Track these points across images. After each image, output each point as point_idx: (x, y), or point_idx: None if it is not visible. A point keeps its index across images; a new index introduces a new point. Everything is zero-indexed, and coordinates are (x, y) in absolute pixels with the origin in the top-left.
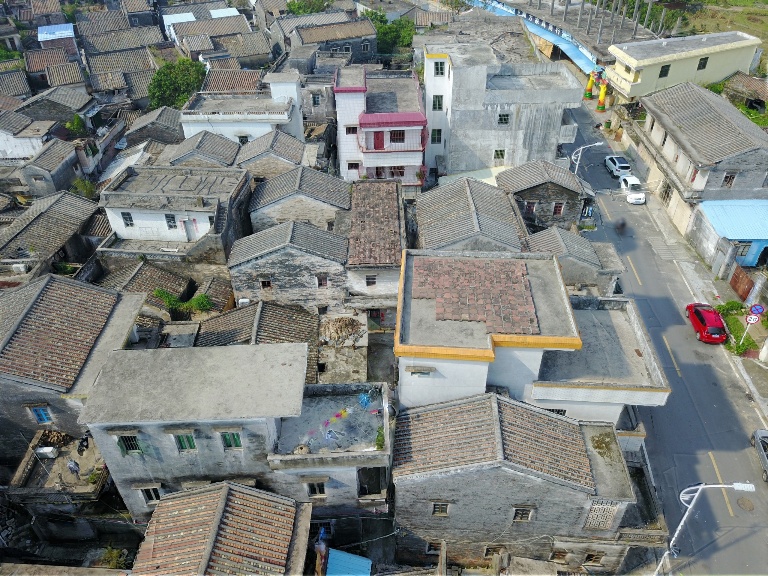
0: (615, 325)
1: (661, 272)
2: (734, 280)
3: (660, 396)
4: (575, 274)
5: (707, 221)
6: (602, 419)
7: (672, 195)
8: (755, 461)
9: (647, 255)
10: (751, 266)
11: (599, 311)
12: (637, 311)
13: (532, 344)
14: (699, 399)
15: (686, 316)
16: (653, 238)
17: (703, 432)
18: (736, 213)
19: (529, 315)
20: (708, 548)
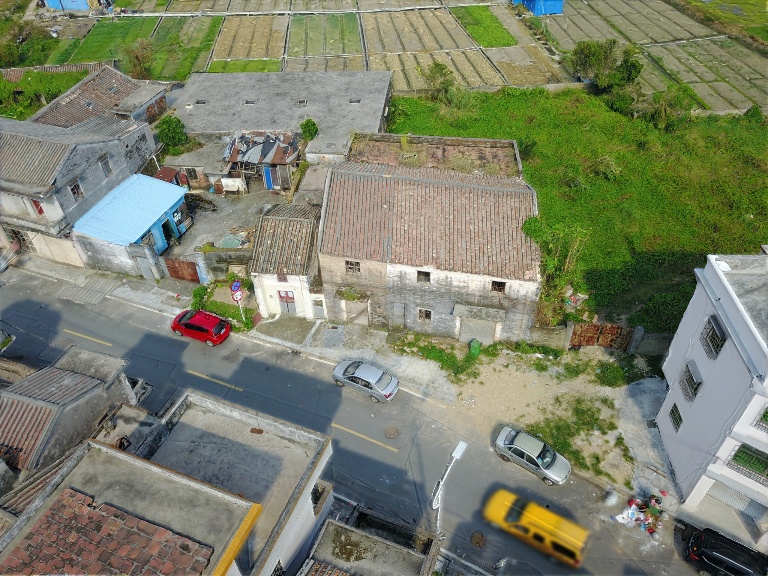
0: (204, 429)
1: (111, 317)
2: (173, 272)
3: (327, 451)
4: (86, 415)
5: (98, 240)
6: (304, 522)
7: (30, 238)
8: (356, 395)
9: (78, 312)
10: (166, 248)
11: (173, 432)
12: (209, 396)
13: (224, 572)
14: (276, 393)
15: (180, 336)
16: (62, 292)
17: (310, 415)
18: (111, 215)
19: (173, 545)
20: (419, 493)
